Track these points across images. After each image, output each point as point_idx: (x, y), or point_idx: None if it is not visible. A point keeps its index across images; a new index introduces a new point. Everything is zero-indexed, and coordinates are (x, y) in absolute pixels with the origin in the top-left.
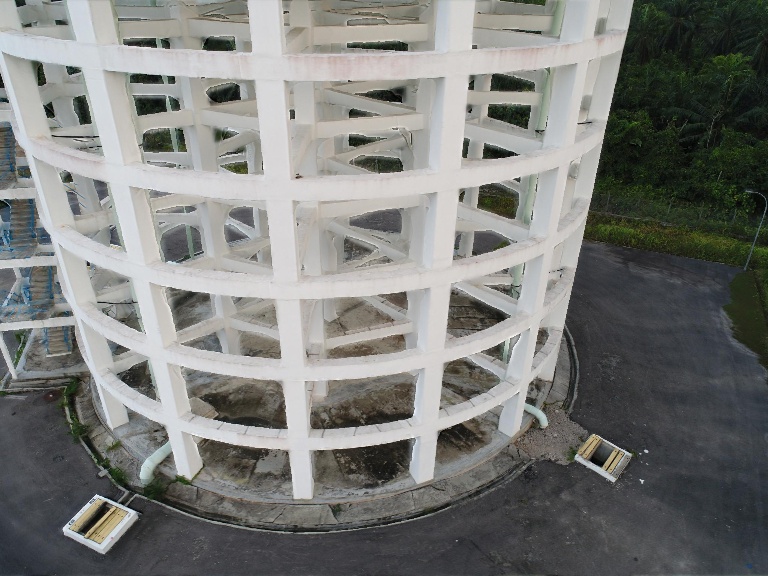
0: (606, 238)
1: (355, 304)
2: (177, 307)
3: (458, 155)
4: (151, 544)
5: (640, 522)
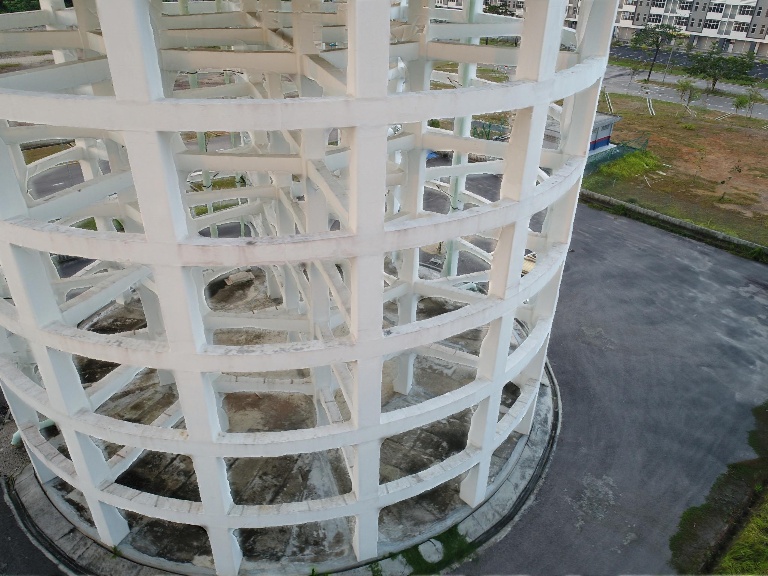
0: None
1: (306, 375)
2: None
3: None
4: None
5: None
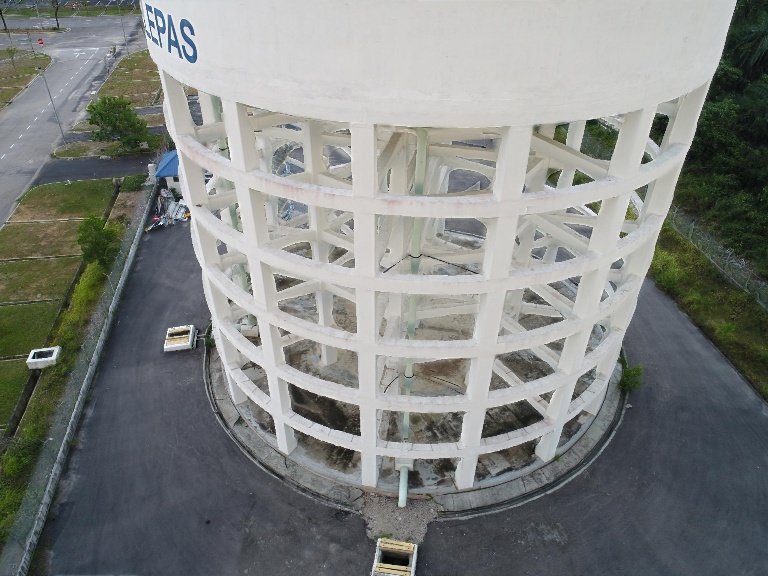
0: None
1: (443, 327)
2: None
3: (254, 237)
4: (179, 363)
5: None
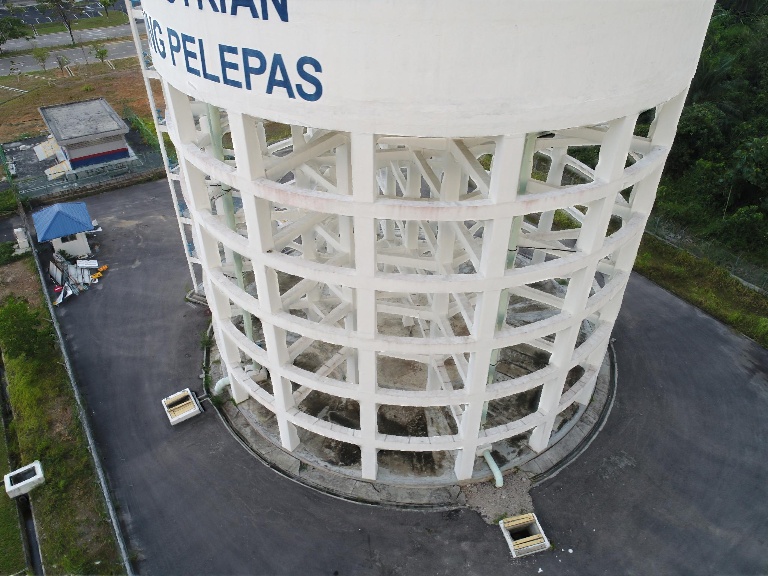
0: (759, 335)
1: None
2: None
3: (371, 268)
4: (197, 432)
5: None
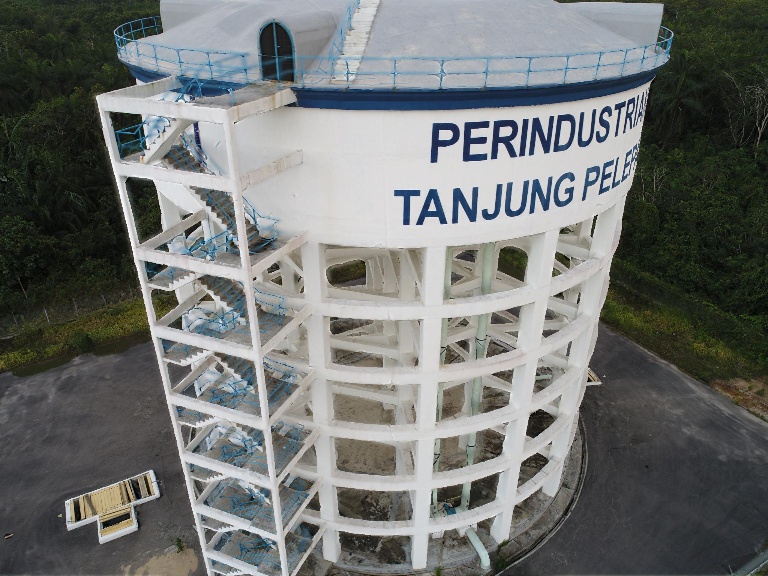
0: None
1: None
2: (283, 480)
3: None
4: None
5: (627, 392)
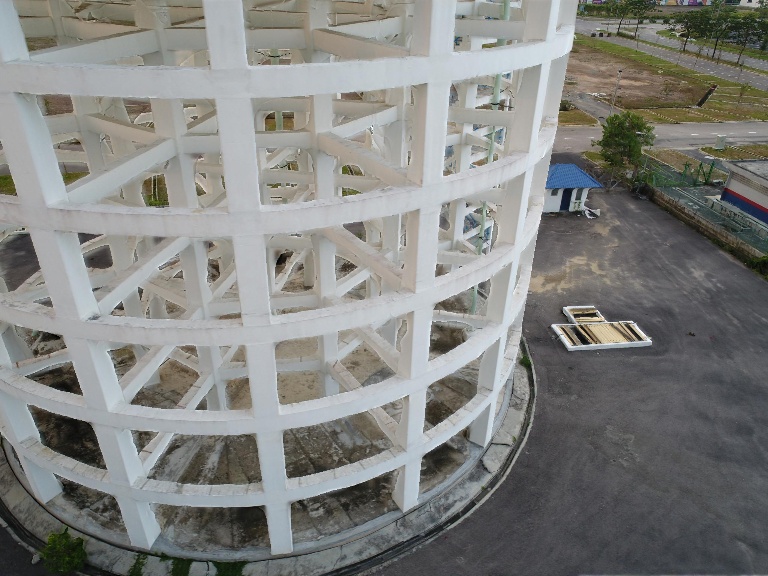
0: None
1: None
2: None
3: None
4: None
5: None
